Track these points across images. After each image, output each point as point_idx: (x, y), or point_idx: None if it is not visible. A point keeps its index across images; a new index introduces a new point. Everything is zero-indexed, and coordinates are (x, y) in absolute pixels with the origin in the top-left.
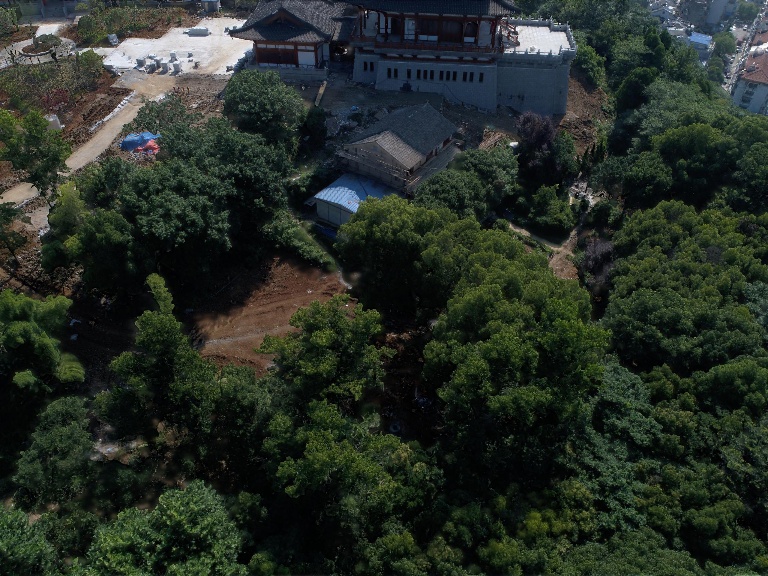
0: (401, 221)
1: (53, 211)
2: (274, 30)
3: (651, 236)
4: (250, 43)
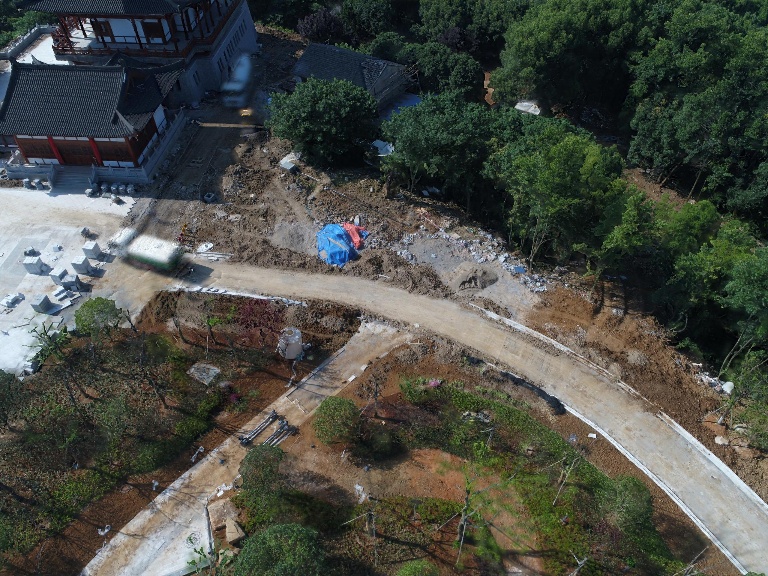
0: (570, 14)
1: (581, 206)
2: (137, 101)
3: (467, 2)
4: (12, 195)
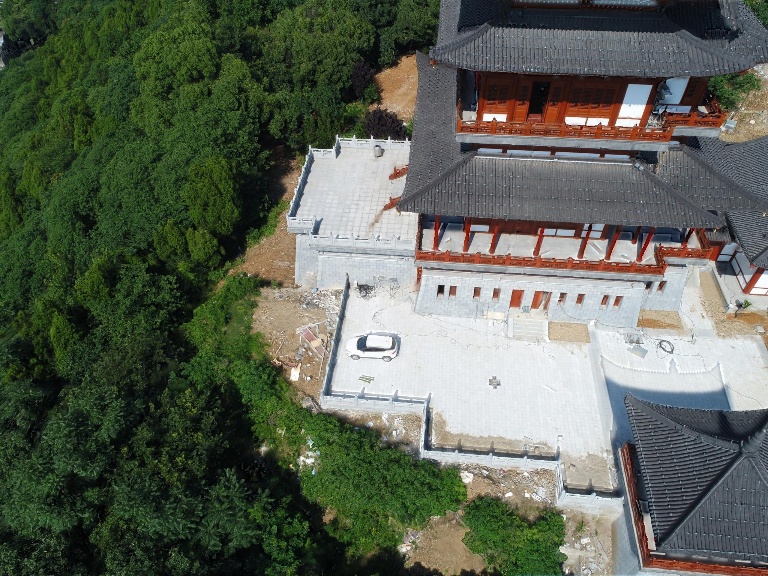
0: None
1: None
2: None
3: None
4: None
